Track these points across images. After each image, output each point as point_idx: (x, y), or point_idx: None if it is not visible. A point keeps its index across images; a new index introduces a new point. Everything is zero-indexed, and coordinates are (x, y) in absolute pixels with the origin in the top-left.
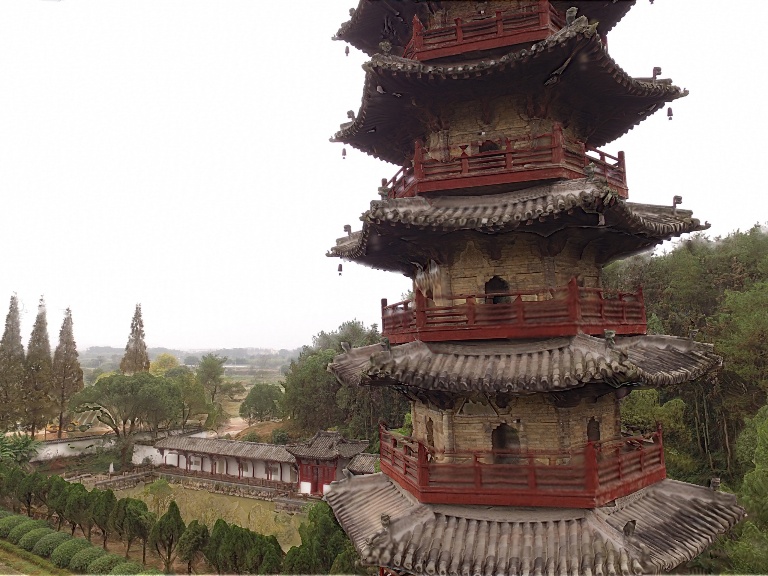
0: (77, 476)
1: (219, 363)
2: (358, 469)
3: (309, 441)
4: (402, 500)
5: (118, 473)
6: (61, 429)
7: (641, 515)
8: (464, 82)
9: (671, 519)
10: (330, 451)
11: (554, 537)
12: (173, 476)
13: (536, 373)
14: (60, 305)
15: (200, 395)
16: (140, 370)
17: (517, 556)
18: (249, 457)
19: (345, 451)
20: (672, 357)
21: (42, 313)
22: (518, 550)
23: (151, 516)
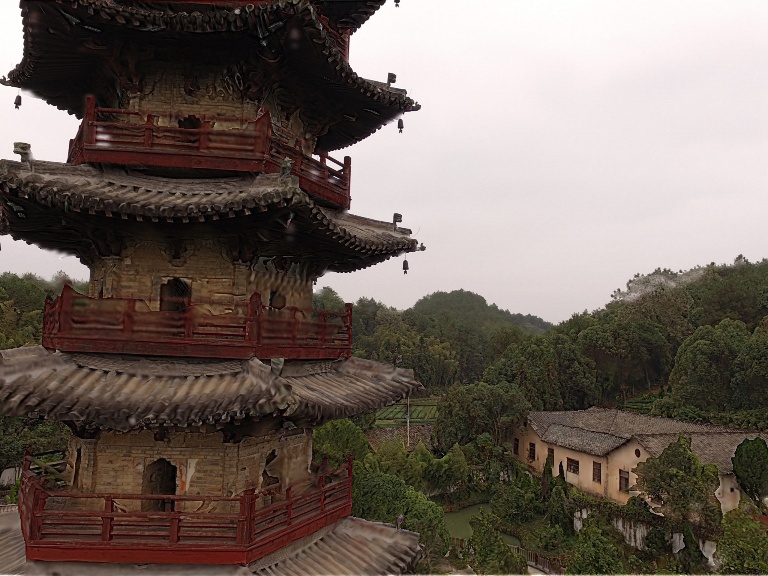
0: None
1: None
2: None
3: None
4: (290, 563)
5: None
6: None
7: None
8: (340, 128)
9: None
10: None
11: None
12: None
13: None
14: None
15: None
16: None
17: None
18: None
19: None
20: None
21: None
22: None
23: None
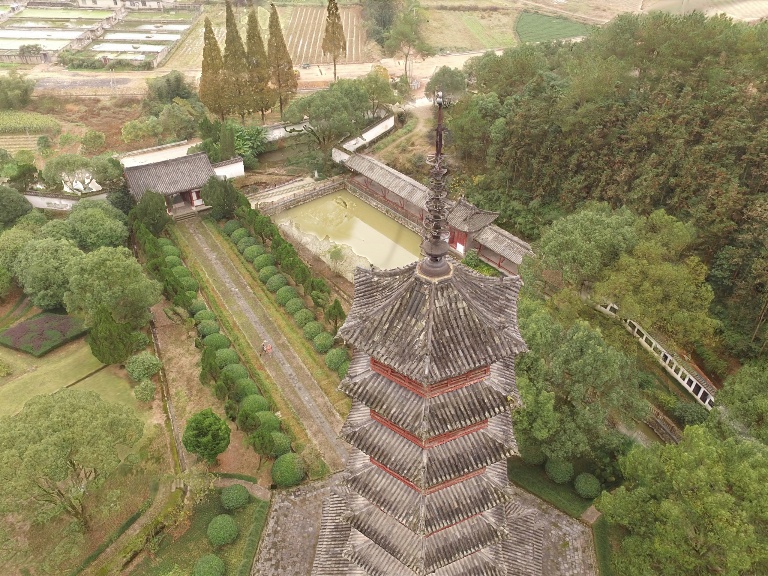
0: (293, 180)
1: (413, 23)
2: (482, 242)
3: (450, 208)
4: None
5: (321, 178)
6: (282, 107)
7: (455, 567)
8: None
9: (469, 570)
10: (463, 224)
11: (408, 574)
12: (358, 191)
13: (400, 548)
14: (265, 2)
15: (385, 96)
16: (338, 52)
17: (392, 575)
18: (409, 201)
19: (476, 223)
20: (484, 532)
21: (252, 12)
22: (394, 573)
23: (326, 297)
